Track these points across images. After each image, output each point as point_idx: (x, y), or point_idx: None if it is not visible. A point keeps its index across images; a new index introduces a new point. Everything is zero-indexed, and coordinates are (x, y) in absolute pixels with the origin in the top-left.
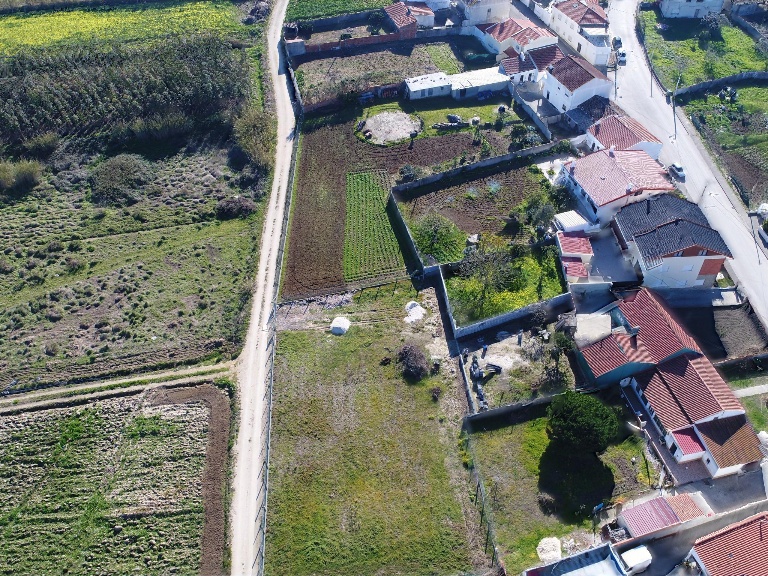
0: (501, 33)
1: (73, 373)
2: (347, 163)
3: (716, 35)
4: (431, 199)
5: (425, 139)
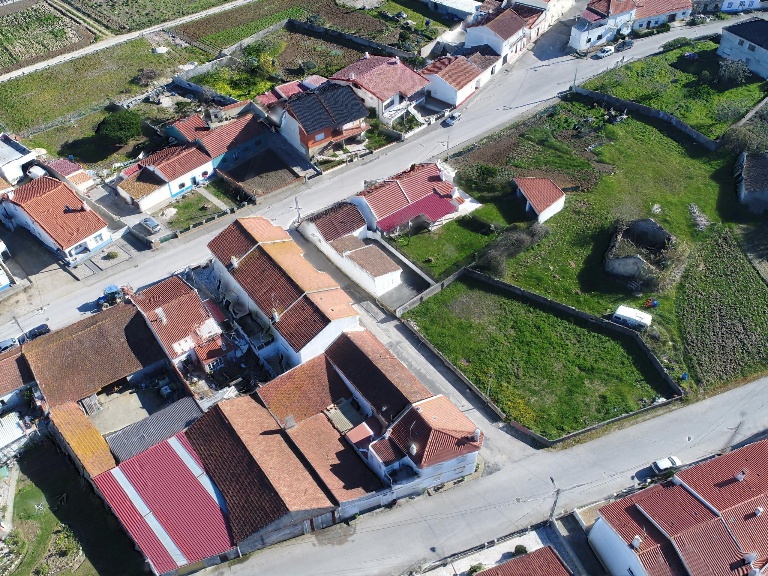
0: None
1: (82, 6)
2: (307, 1)
3: (723, 84)
4: (300, 37)
5: (362, 14)
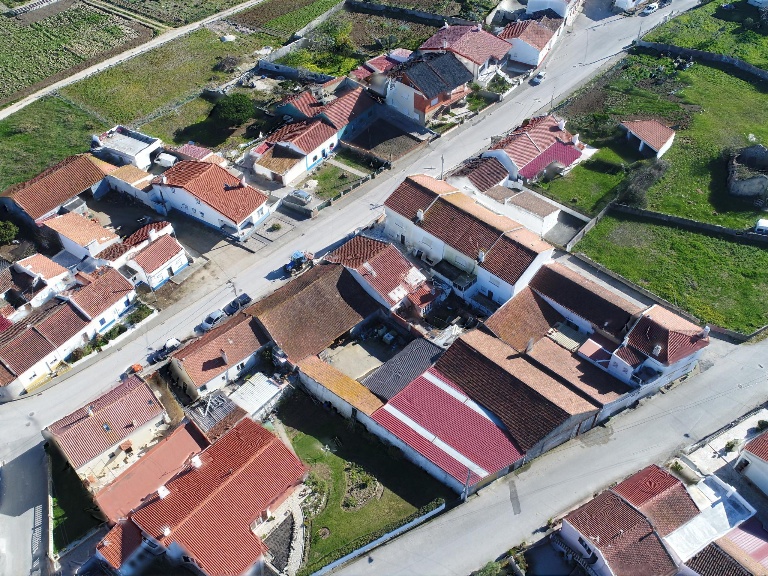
0: None
1: (123, 3)
2: None
3: (765, 29)
4: (363, 16)
5: None
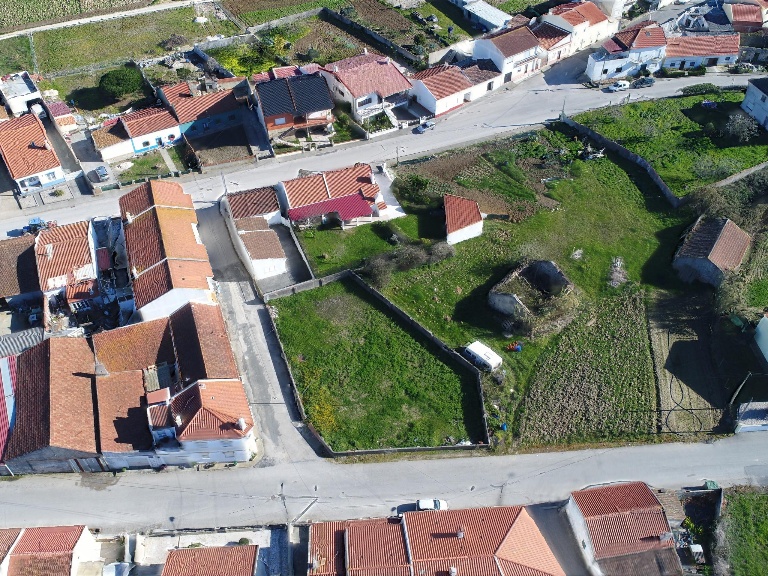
0: (565, 5)
1: None
2: None
3: (727, 140)
4: (327, 26)
5: (396, 12)
